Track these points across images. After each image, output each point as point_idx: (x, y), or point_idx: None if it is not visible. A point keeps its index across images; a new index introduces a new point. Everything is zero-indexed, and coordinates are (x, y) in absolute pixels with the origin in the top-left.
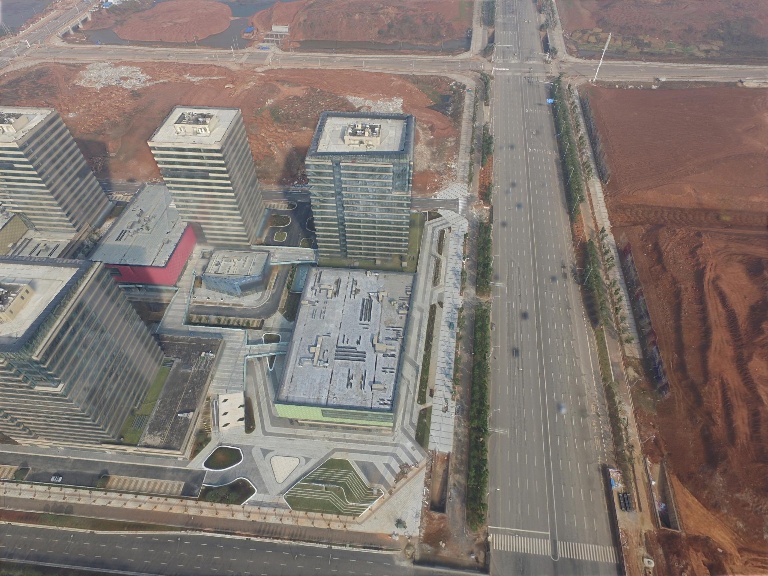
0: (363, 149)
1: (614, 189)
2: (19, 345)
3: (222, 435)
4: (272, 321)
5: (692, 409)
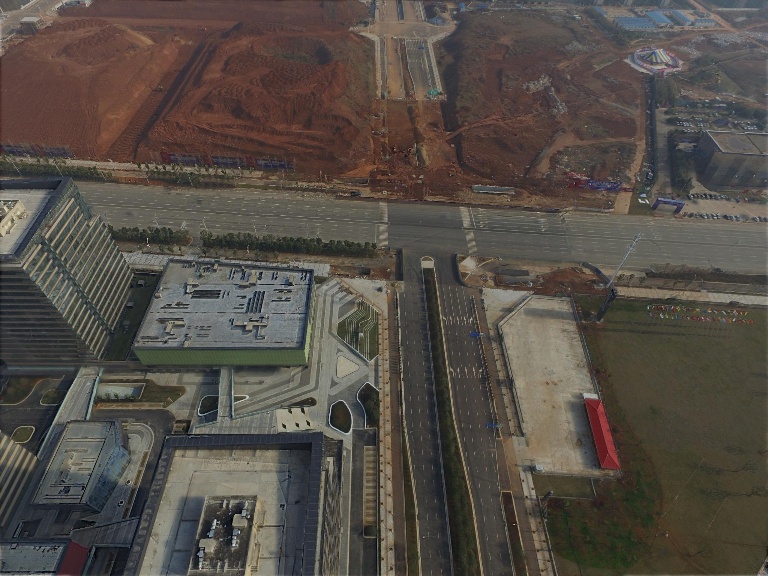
0: (25, 221)
1: (86, 153)
2: (314, 436)
3: (318, 425)
4: (180, 411)
5: (301, 159)
